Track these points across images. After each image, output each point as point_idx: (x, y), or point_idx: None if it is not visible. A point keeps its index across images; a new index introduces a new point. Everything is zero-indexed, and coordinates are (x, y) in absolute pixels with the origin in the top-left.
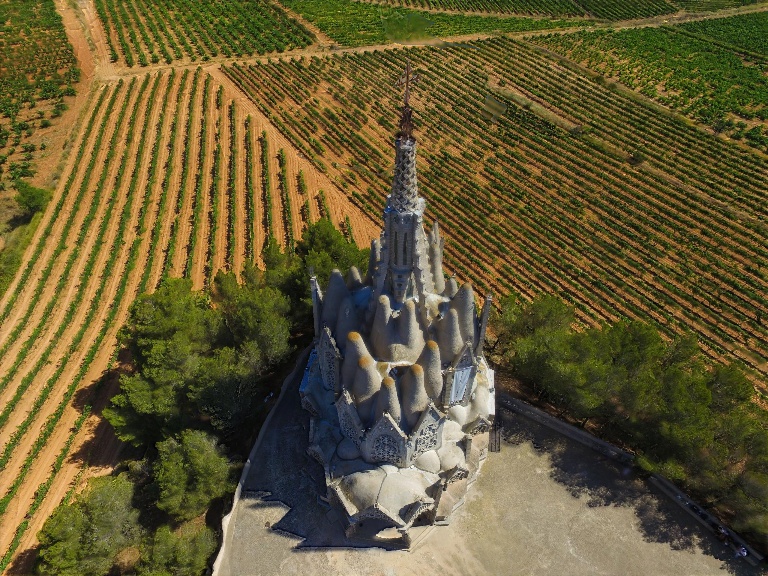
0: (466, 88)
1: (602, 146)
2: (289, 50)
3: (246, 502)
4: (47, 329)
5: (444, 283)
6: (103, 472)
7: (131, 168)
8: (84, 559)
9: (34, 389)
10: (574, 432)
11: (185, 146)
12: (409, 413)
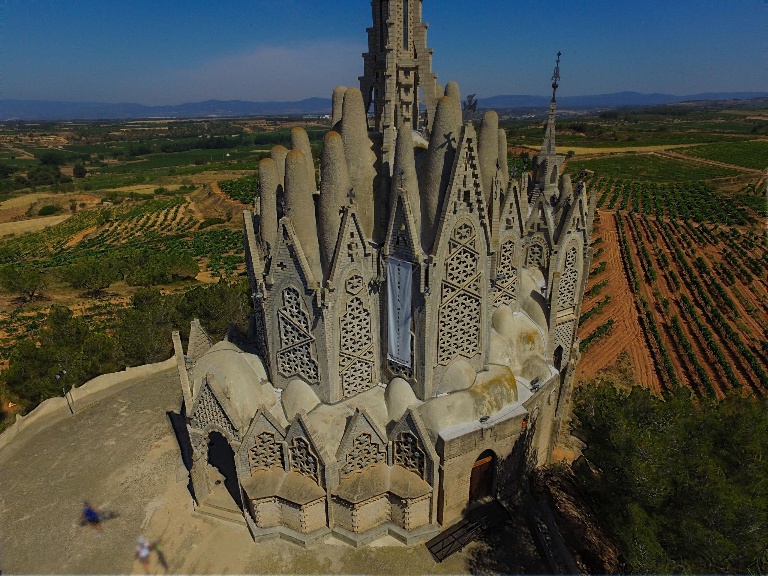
0: None
1: None
2: (709, 223)
3: None
4: None
5: None
6: None
7: None
8: None
9: None
10: None
11: None
12: None
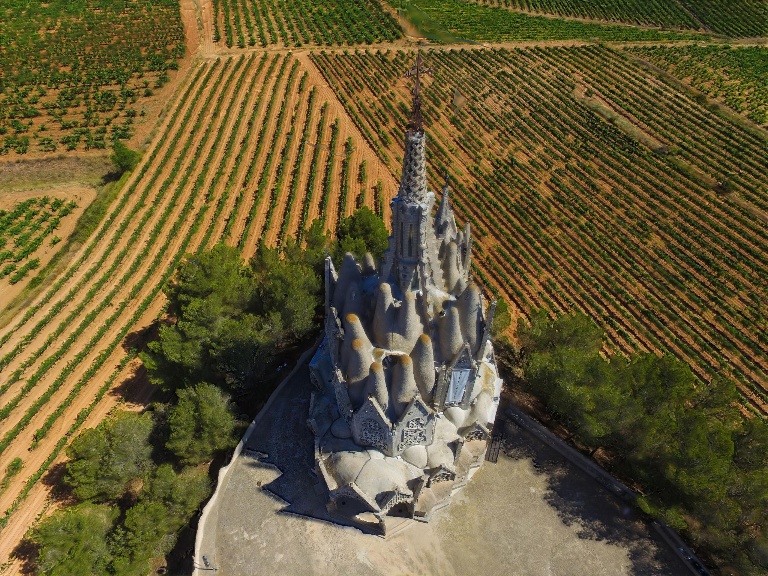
0: (549, 95)
1: (687, 170)
2: (377, 43)
3: (244, 459)
4: (115, 275)
5: None
6: (135, 409)
7: (212, 141)
8: (101, 479)
9: (95, 326)
10: (579, 459)
11: (263, 125)
12: (396, 402)
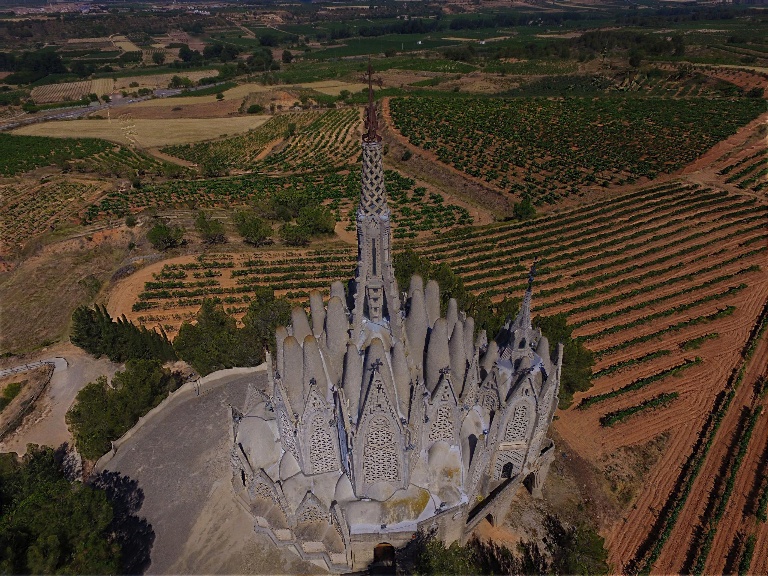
0: None
1: None
2: None
3: None
4: None
5: (439, 374)
6: None
7: None
8: None
9: None
10: None
11: None
12: None
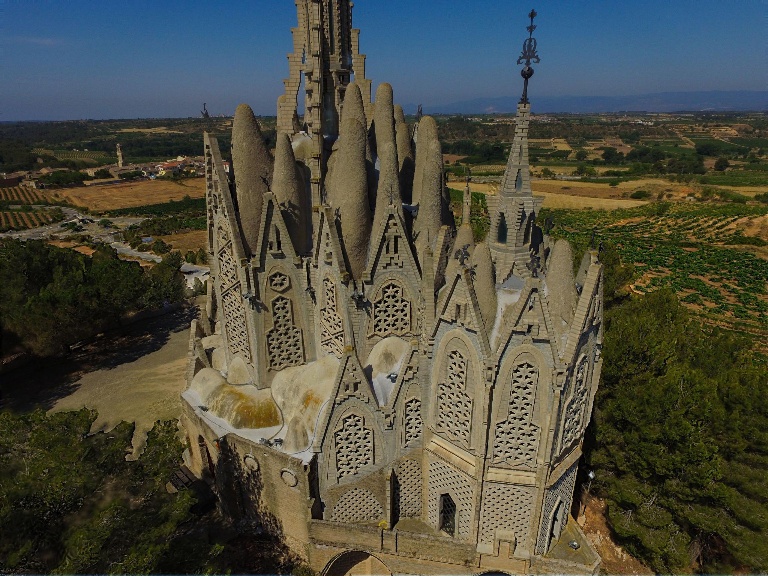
0: None
1: None
2: None
3: None
4: None
5: (335, 219)
6: None
7: None
8: None
9: None
10: None
11: None
12: None
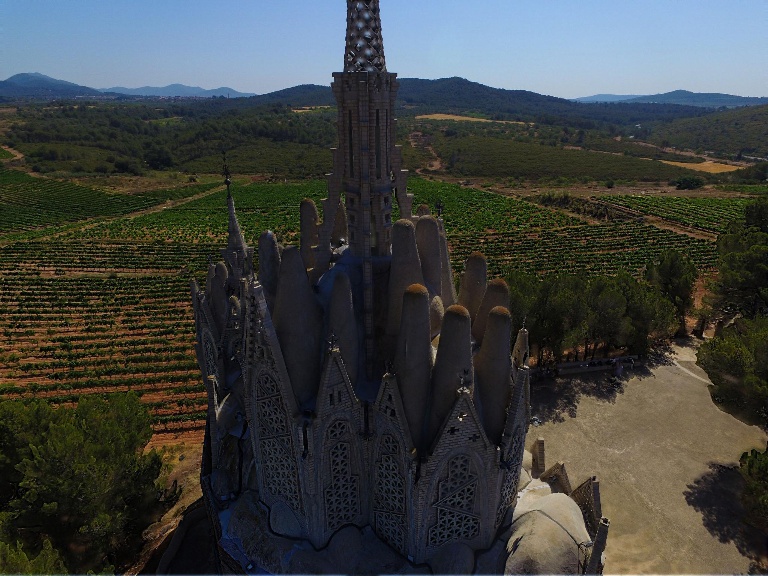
0: None
1: None
2: None
3: None
4: None
5: None
6: None
7: None
8: None
9: None
10: None
11: None
12: None
